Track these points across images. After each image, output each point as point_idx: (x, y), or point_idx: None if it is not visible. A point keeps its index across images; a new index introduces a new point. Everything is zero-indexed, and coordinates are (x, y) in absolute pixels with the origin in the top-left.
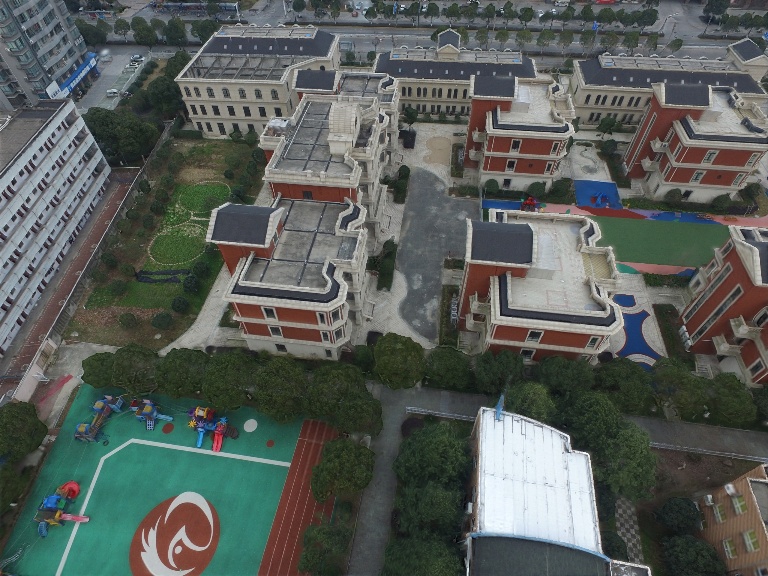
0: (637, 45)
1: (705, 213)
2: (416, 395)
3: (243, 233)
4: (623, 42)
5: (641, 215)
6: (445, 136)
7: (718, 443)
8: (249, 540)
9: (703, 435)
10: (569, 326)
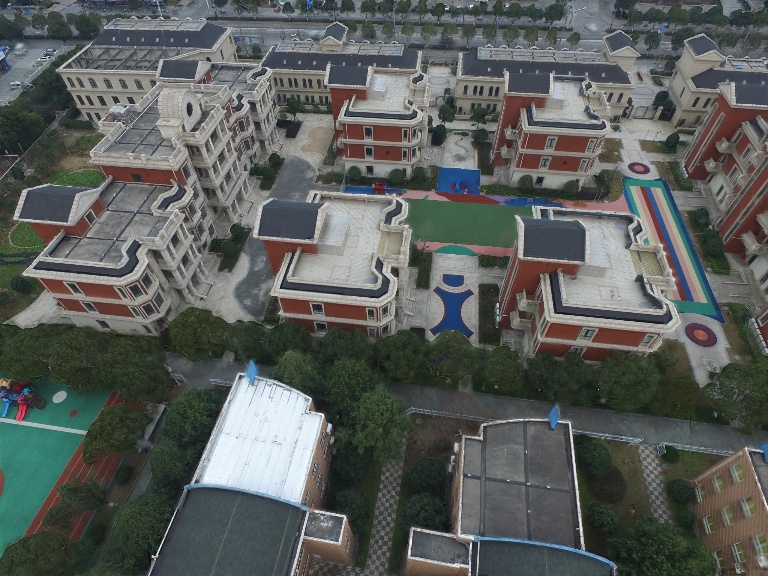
0: (536, 39)
1: (556, 198)
2: (227, 368)
3: (49, 211)
4: (524, 36)
5: (495, 201)
6: (329, 126)
7: (500, 412)
8: (26, 501)
9: (489, 405)
10: (341, 298)
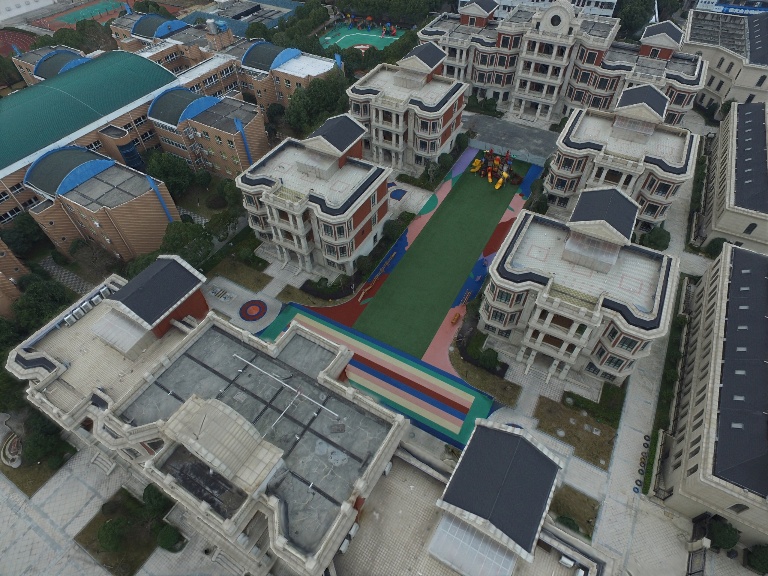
0: None
1: None
2: None
3: None
4: None
5: (489, 254)
6: None
7: None
8: None
9: None
10: None
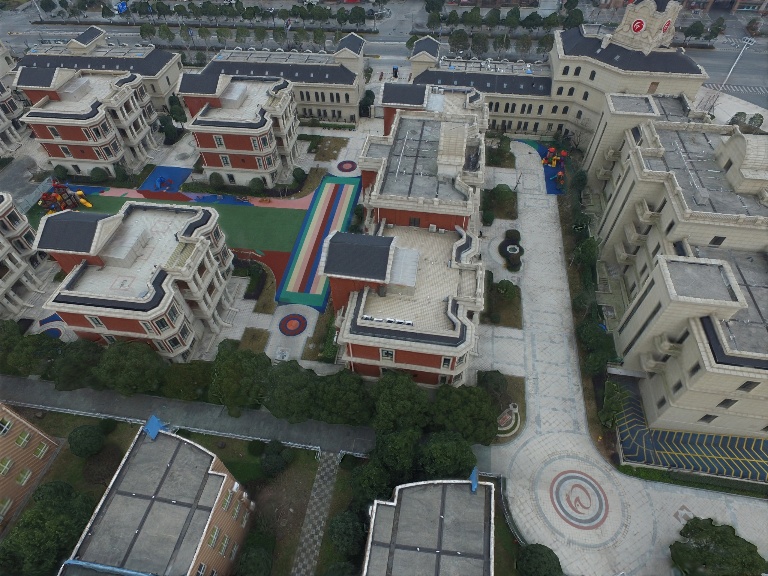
0: (323, 41)
1: (246, 195)
2: None
3: None
4: None
5: (188, 198)
6: None
7: (52, 398)
8: None
9: (46, 391)
10: None
